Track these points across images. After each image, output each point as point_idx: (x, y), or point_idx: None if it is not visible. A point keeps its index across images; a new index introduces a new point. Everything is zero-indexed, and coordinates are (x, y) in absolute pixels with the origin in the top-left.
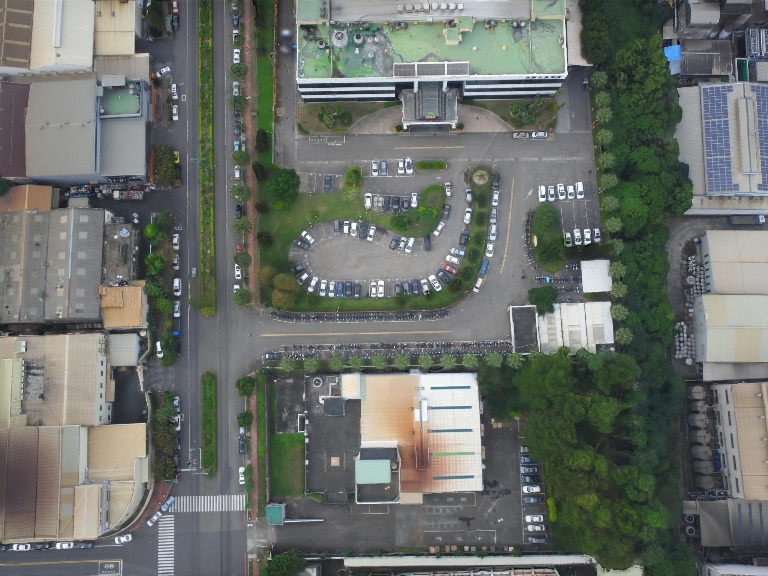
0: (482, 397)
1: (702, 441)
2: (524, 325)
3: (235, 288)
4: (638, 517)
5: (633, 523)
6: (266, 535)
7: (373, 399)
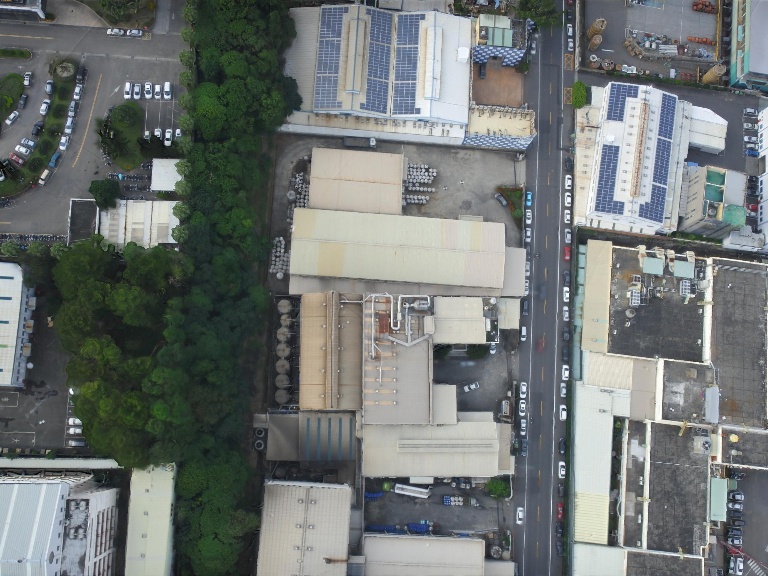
0: (36, 293)
1: (281, 354)
2: (83, 219)
3: None
4: (145, 409)
5: (137, 414)
6: None
7: None
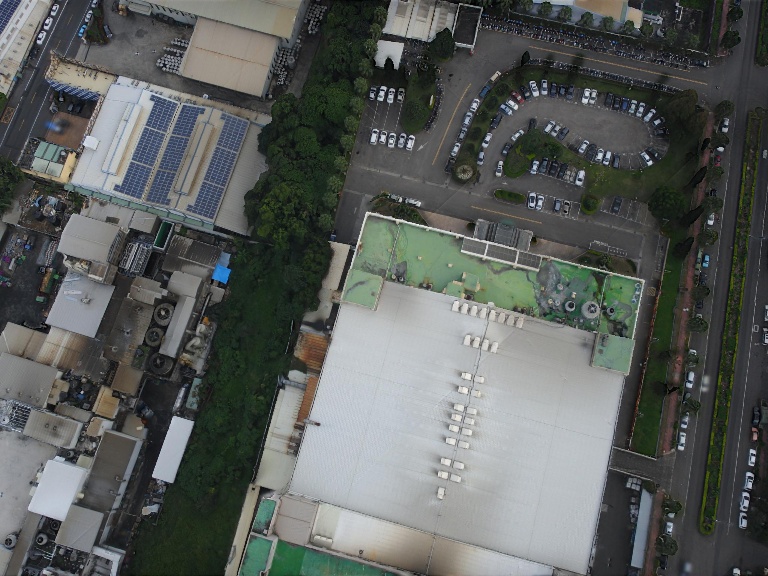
0: None
1: None
2: (466, 30)
3: (727, 129)
4: None
5: None
6: None
7: (617, 1)
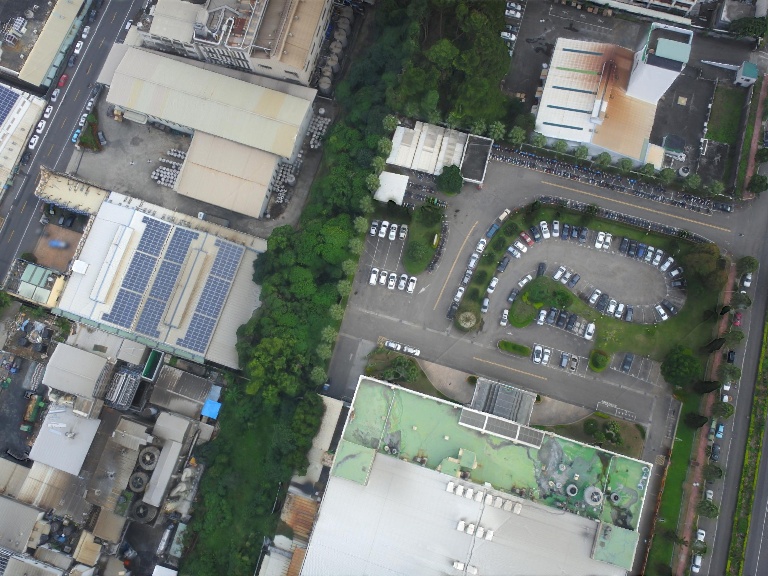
0: None
1: (339, 44)
2: (475, 163)
3: (749, 283)
4: None
5: None
6: (759, 61)
7: (638, 138)
